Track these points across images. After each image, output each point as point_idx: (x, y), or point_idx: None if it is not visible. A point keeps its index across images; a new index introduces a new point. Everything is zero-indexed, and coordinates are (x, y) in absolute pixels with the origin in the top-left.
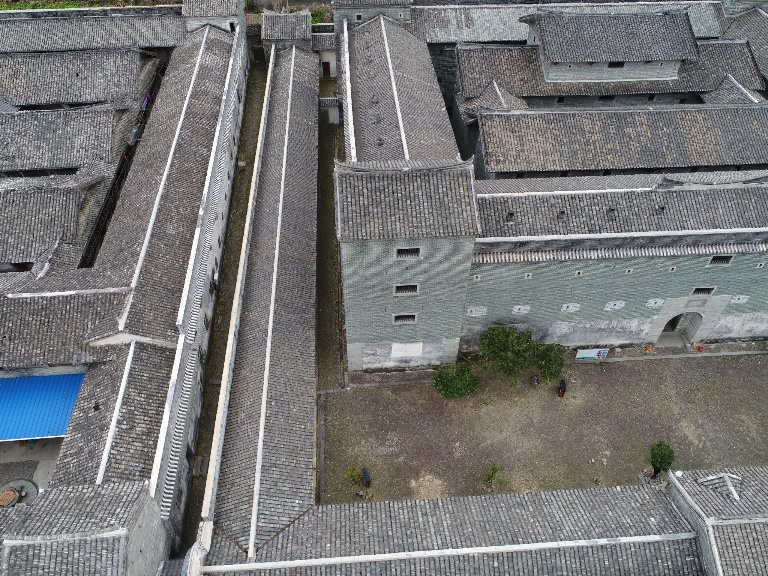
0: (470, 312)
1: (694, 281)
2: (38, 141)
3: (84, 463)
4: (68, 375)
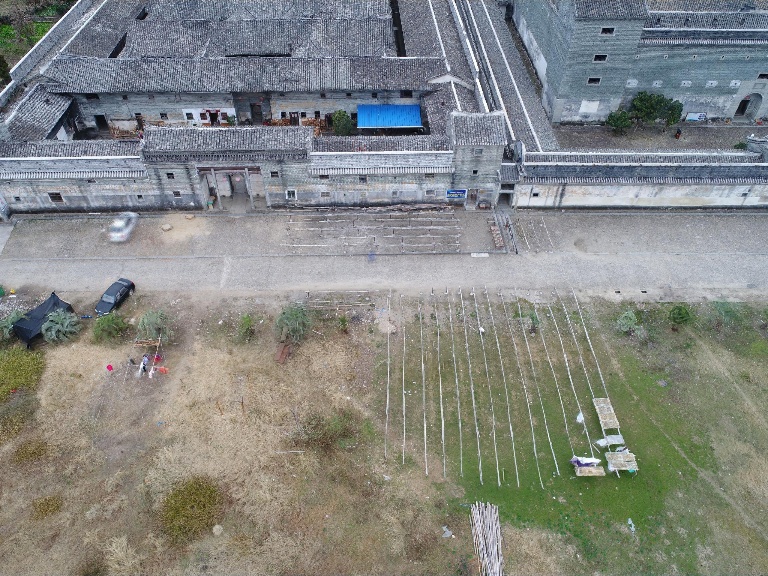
0: (628, 84)
1: (759, 68)
2: (344, 4)
3: None
4: (407, 105)
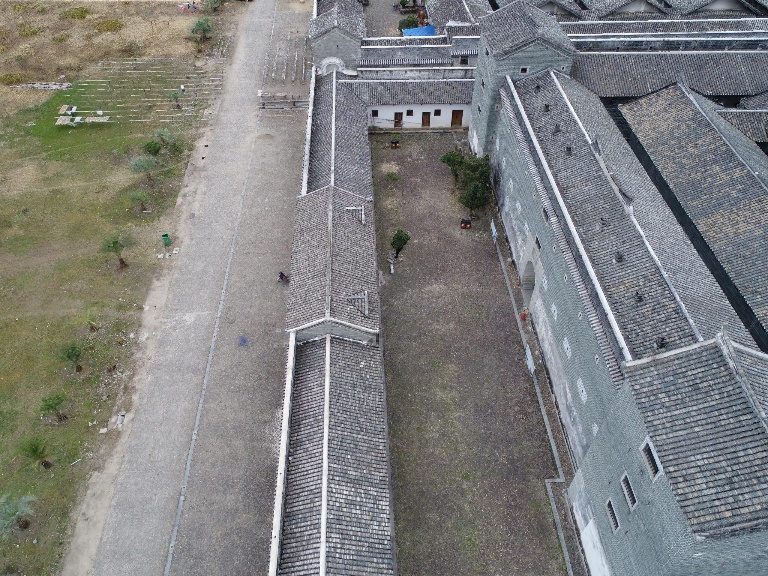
0: None
1: None
2: None
3: None
4: None
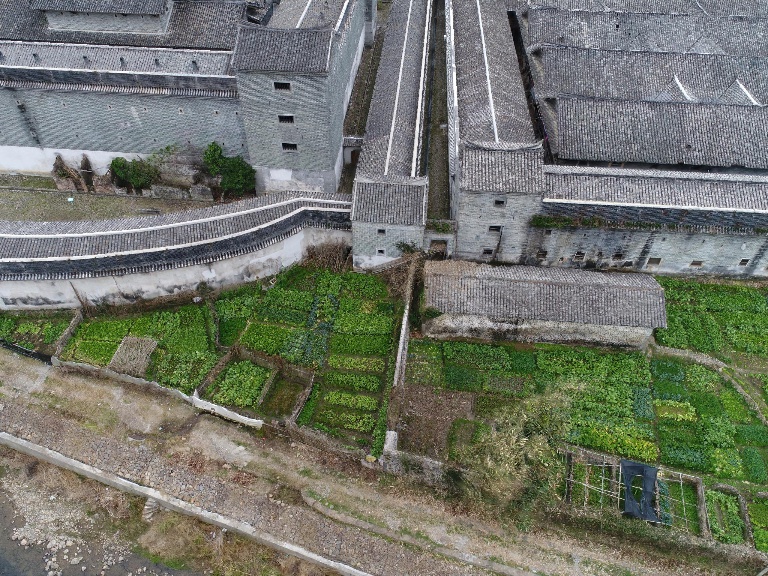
0: None
1: None
2: None
3: None
4: None
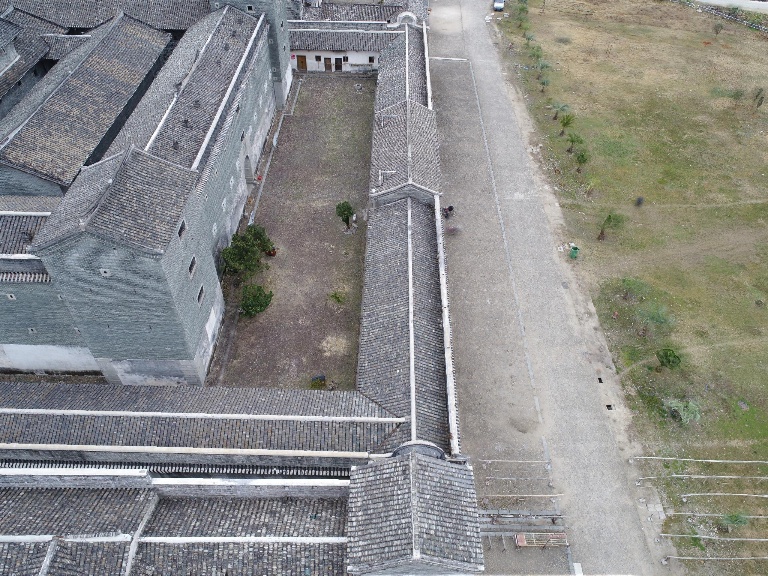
0: None
1: None
2: None
3: (298, 572)
4: None
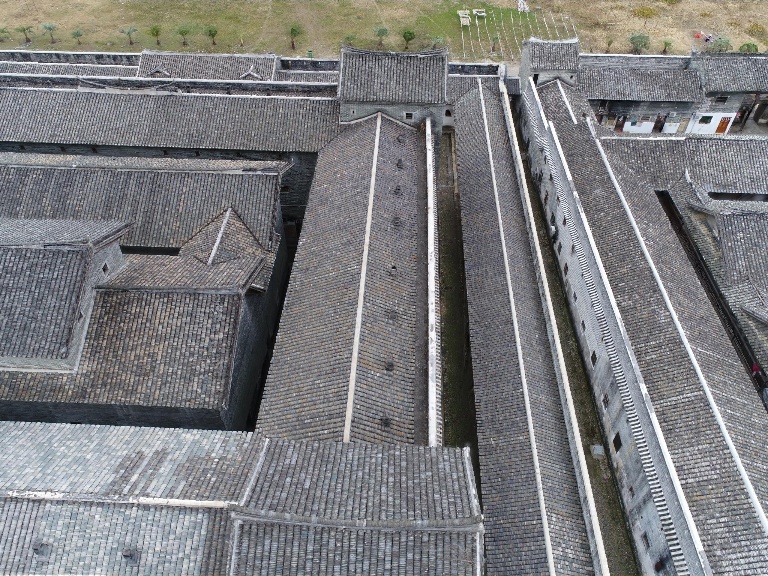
0: None
1: None
2: None
3: None
4: None
